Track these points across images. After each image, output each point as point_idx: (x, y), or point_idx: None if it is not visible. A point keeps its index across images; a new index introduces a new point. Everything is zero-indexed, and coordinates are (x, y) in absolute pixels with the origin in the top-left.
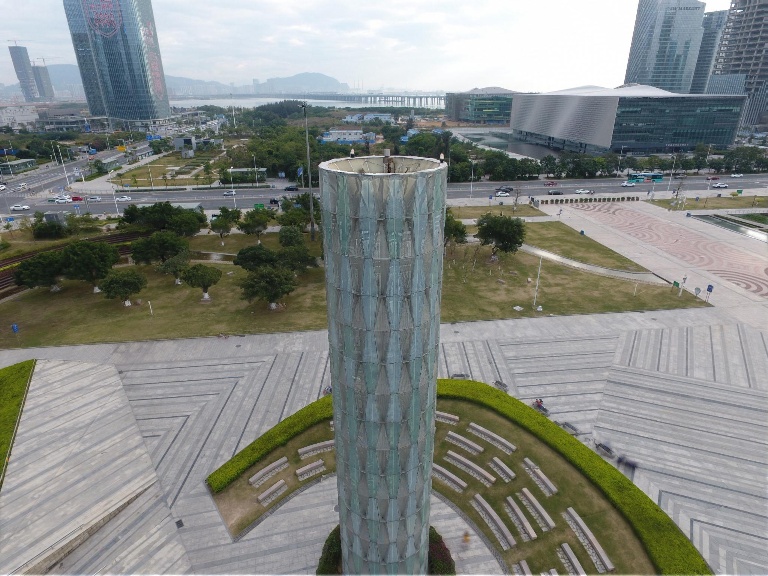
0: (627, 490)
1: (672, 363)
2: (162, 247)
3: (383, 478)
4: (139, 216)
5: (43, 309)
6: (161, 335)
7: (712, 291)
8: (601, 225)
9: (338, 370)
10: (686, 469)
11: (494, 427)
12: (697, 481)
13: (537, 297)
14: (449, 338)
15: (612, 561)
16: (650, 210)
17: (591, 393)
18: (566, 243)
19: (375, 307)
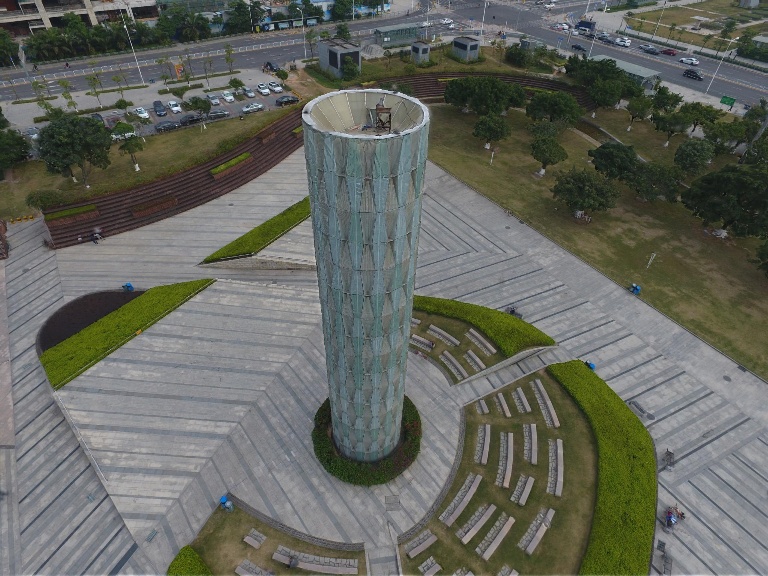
0: None
1: None
2: (552, 108)
3: None
4: (575, 68)
5: (443, 122)
6: (475, 184)
7: None
8: None
9: None
10: None
11: (574, 465)
12: None
13: None
14: (704, 375)
15: None
16: None
17: None
18: None
19: None
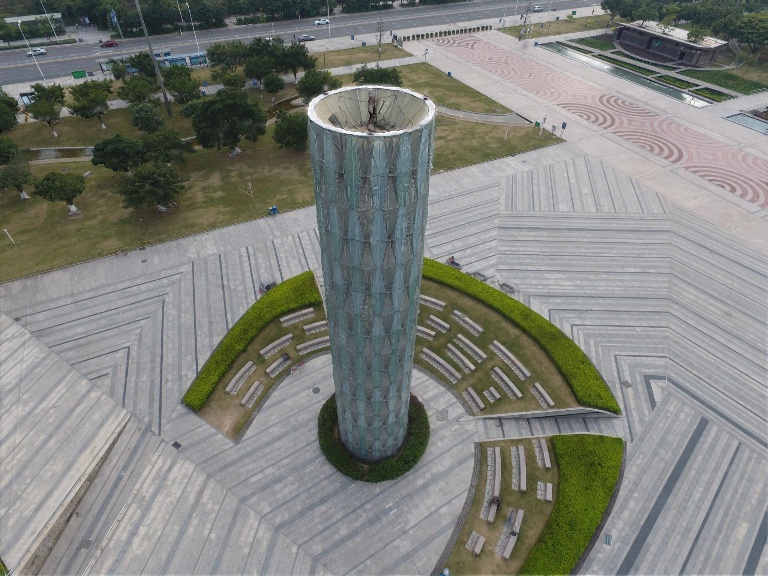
0: (530, 316)
1: (543, 201)
2: None
3: (385, 372)
4: None
5: None
6: (42, 266)
7: (565, 128)
8: (464, 63)
9: (343, 302)
10: (563, 289)
11: (424, 290)
12: (571, 296)
13: None
14: None
15: (529, 370)
16: (504, 41)
17: (488, 241)
18: (437, 88)
19: (384, 250)
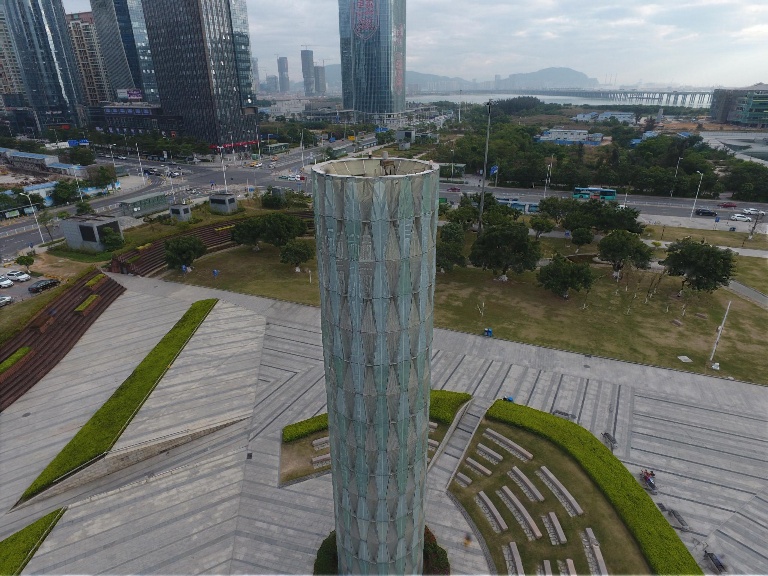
0: None
1: None
2: None
3: (354, 473)
4: None
5: (242, 262)
6: (309, 301)
7: None
8: None
9: None
10: None
11: (568, 480)
12: None
13: (720, 352)
14: (574, 370)
15: None
16: None
17: (735, 489)
18: None
19: (339, 304)
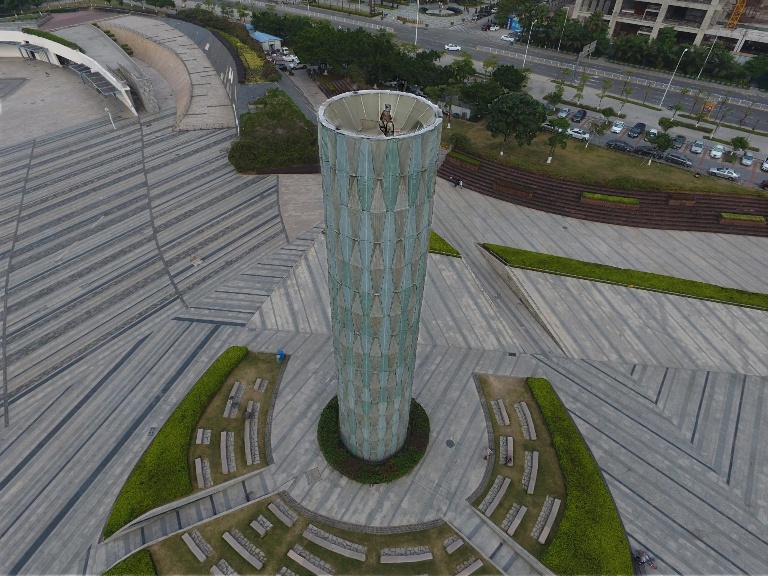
0: None
1: None
2: None
3: None
4: None
5: None
6: None
7: None
8: None
9: None
10: None
11: None
12: None
13: None
14: None
15: None
16: None
17: None
18: None
19: None
